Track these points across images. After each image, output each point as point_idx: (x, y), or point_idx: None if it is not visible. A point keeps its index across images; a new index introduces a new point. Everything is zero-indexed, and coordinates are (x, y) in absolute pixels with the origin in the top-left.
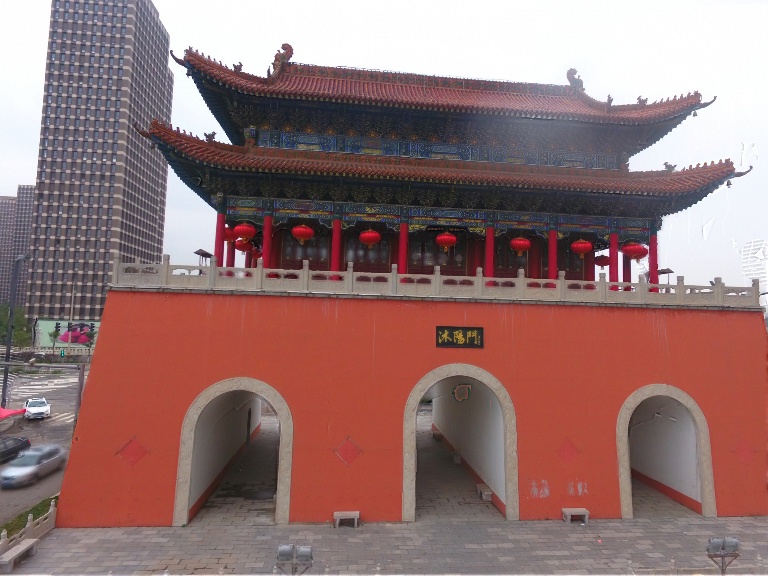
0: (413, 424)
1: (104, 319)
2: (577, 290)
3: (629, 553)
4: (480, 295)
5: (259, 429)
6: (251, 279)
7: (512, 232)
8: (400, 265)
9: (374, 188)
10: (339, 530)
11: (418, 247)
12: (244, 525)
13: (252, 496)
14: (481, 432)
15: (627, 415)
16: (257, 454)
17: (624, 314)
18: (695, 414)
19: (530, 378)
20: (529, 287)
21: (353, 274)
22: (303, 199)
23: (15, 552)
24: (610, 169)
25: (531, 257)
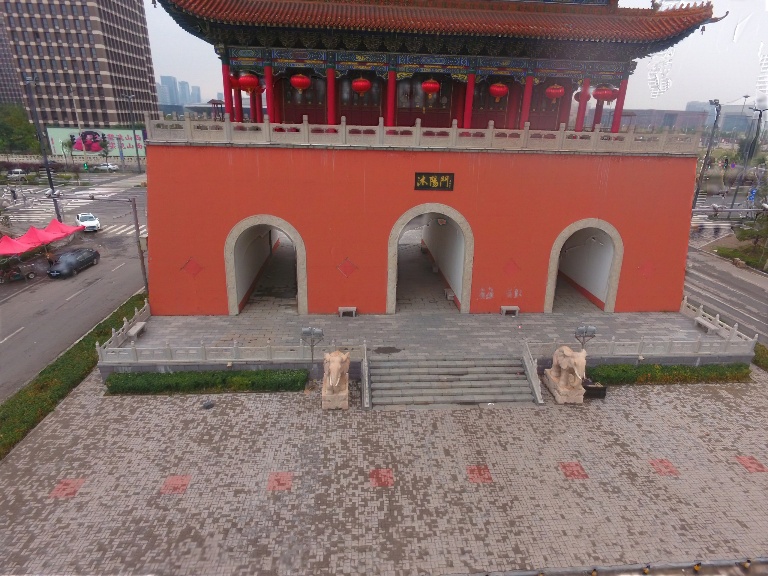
0: (395, 249)
1: (149, 169)
2: (538, 139)
3: (536, 334)
4: (454, 145)
5: (278, 243)
6: (261, 133)
7: (492, 78)
8: (388, 113)
9: (364, 35)
10: (342, 318)
11: (407, 89)
12: (277, 315)
13: (280, 296)
14: (451, 252)
15: (561, 242)
16: (280, 264)
17: (575, 161)
18: (616, 241)
19: (489, 214)
20: (497, 137)
21: (346, 127)
22: (298, 48)
23: (135, 330)
24: (599, 4)
25: (511, 98)
